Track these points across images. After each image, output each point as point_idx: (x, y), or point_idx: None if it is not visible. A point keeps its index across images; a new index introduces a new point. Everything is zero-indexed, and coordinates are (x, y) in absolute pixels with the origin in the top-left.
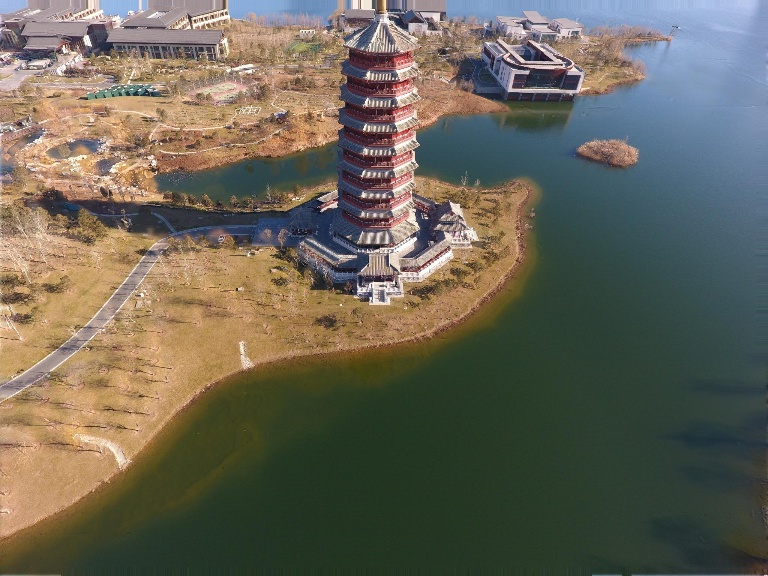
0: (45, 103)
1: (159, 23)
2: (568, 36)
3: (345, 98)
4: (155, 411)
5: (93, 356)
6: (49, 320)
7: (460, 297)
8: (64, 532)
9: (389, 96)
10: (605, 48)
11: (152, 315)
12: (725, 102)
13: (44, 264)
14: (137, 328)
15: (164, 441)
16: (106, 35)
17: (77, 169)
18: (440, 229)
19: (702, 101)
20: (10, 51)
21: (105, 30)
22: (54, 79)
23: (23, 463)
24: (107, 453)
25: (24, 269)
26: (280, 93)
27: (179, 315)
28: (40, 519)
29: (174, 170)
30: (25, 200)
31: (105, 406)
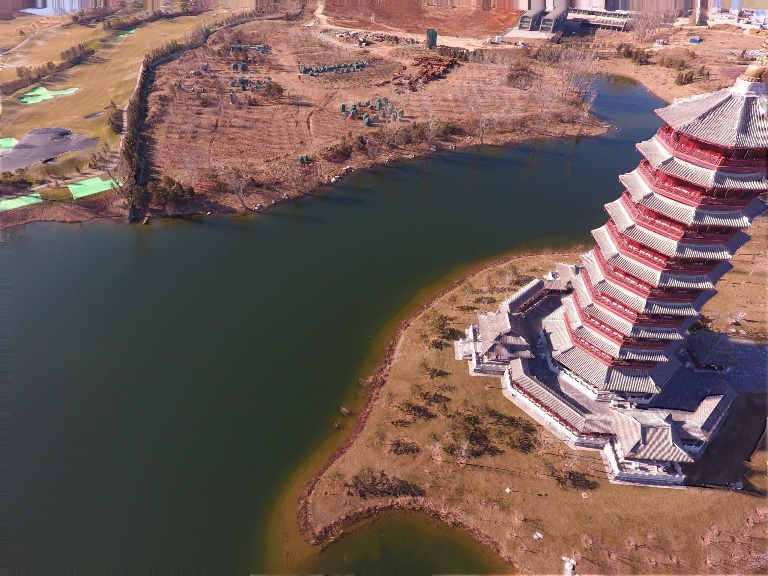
0: None
1: None
2: None
3: None
4: None
5: None
6: None
7: None
8: None
9: None
10: None
11: (765, 264)
12: None
13: None
14: (764, 256)
15: None
16: None
17: None
18: None
19: None
20: None
21: None
22: None
23: None
24: None
25: None
26: None
27: (741, 264)
28: None
29: None
30: None
31: None
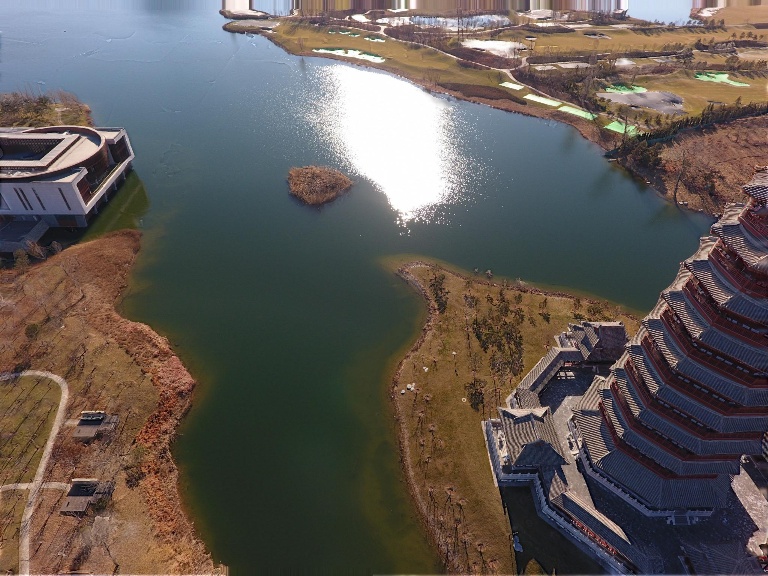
0: None
1: None
2: None
3: None
4: None
5: None
6: None
7: None
8: None
9: None
10: None
11: None
12: (193, 90)
13: None
14: None
15: None
16: None
17: None
18: None
19: (185, 98)
20: None
21: None
22: None
23: None
24: None
25: None
26: None
27: None
28: None
29: None
30: None
31: None
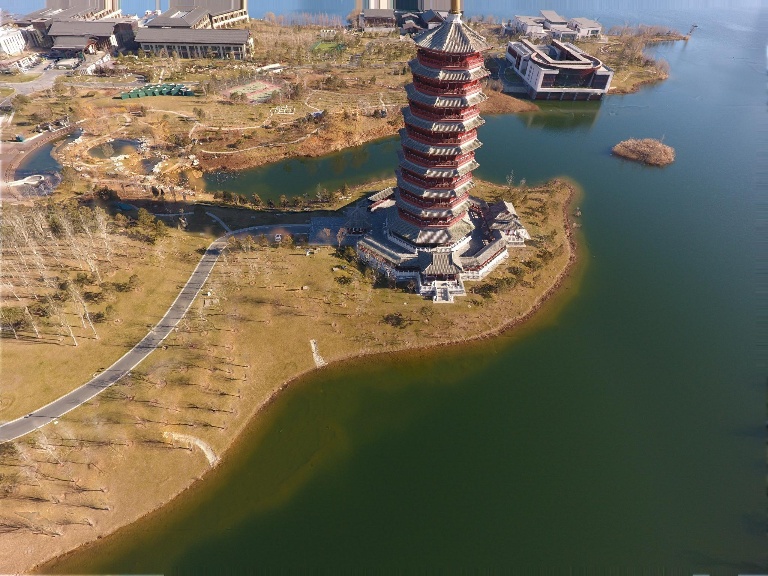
0: (80, 103)
1: (183, 23)
2: (588, 35)
3: (414, 98)
4: (237, 409)
5: (170, 354)
6: (121, 319)
7: (520, 295)
8: (165, 529)
9: (459, 96)
10: (626, 47)
11: (222, 314)
12: (751, 101)
13: (109, 263)
14: (209, 327)
15: (250, 439)
16: (132, 35)
17: (121, 169)
18: (495, 228)
19: (728, 100)
20: (36, 51)
21: (131, 30)
22: (85, 79)
23: (118, 460)
24: (197, 450)
25: (96, 268)
26: (312, 92)
27: (249, 314)
28: (140, 516)
29: (216, 169)
30: (78, 200)
31: (189, 404)
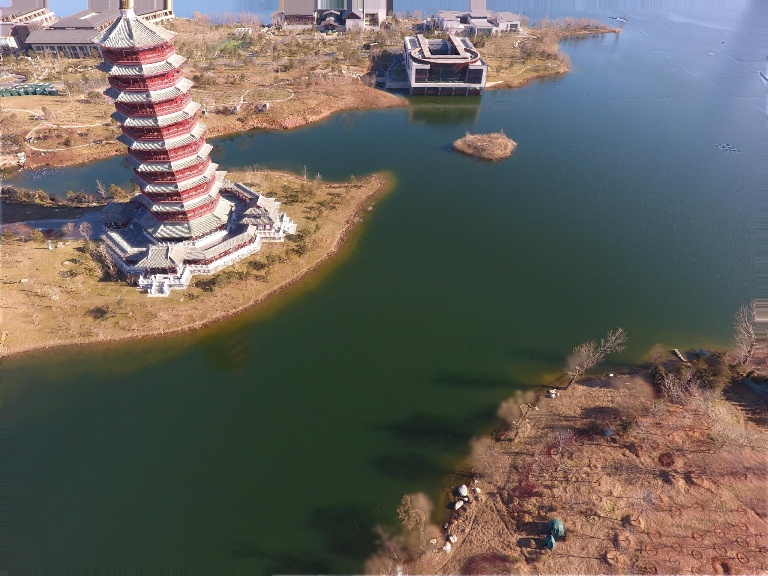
0: None
1: (87, 24)
2: (507, 29)
3: (108, 93)
4: None
5: None
6: None
7: (247, 289)
8: None
9: (142, 90)
10: (538, 41)
11: None
12: (640, 94)
13: None
14: None
15: None
16: None
17: None
18: (246, 222)
19: (615, 93)
20: None
21: (28, 31)
22: None
23: None
24: None
25: None
26: None
27: None
28: None
29: (39, 167)
30: None
31: None
